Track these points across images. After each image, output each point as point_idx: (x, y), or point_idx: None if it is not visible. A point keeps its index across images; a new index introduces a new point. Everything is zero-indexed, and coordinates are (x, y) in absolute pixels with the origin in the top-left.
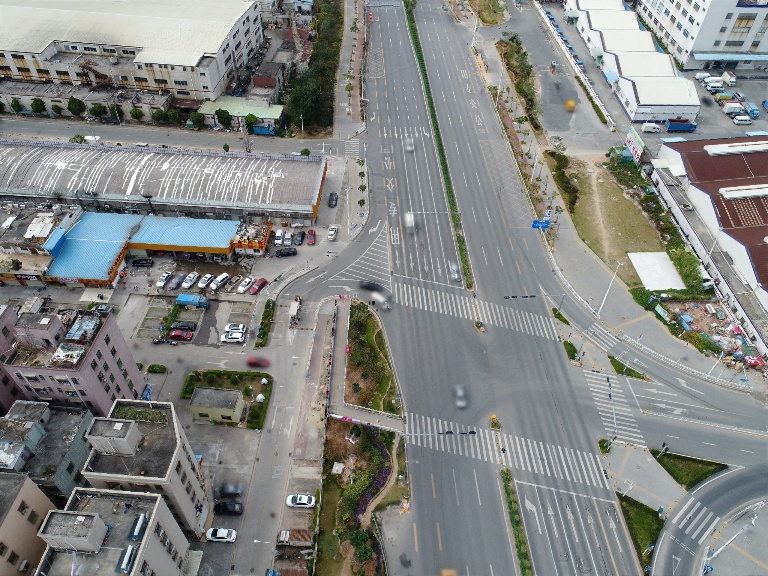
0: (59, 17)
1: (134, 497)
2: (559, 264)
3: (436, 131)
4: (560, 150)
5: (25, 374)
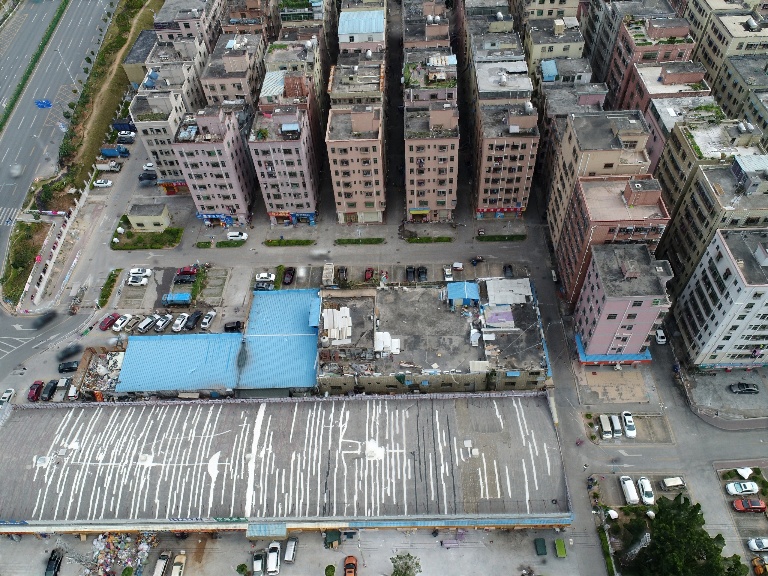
0: None
1: None
2: None
3: None
4: None
5: None
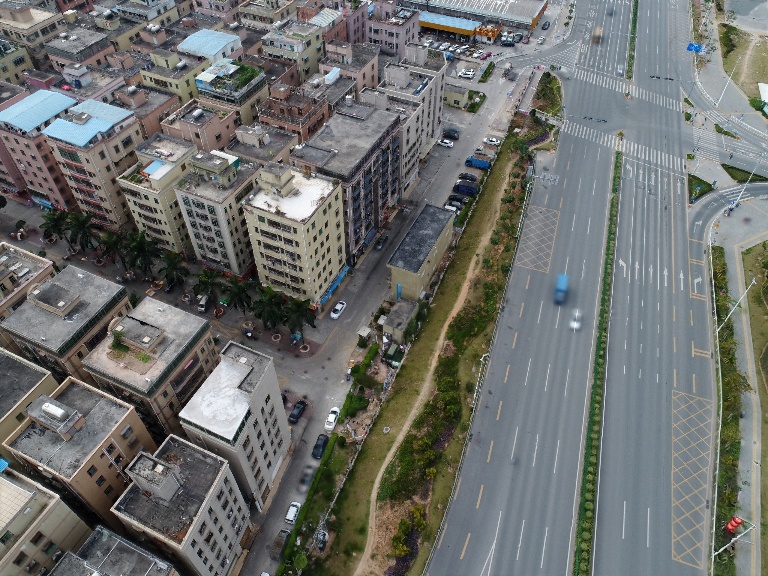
0: None
1: (422, 77)
2: (701, 80)
3: (636, 0)
4: (731, 19)
5: (374, 27)
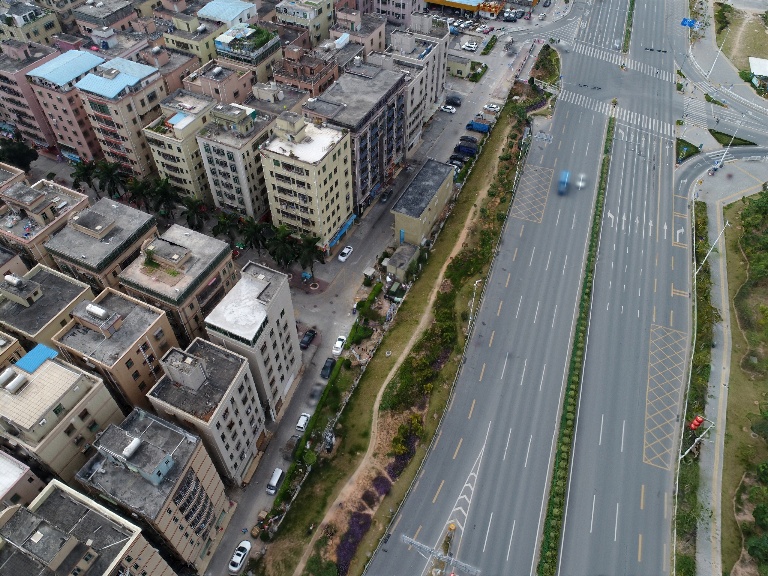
0: None
1: (427, 43)
2: (694, 54)
3: None
4: None
5: None
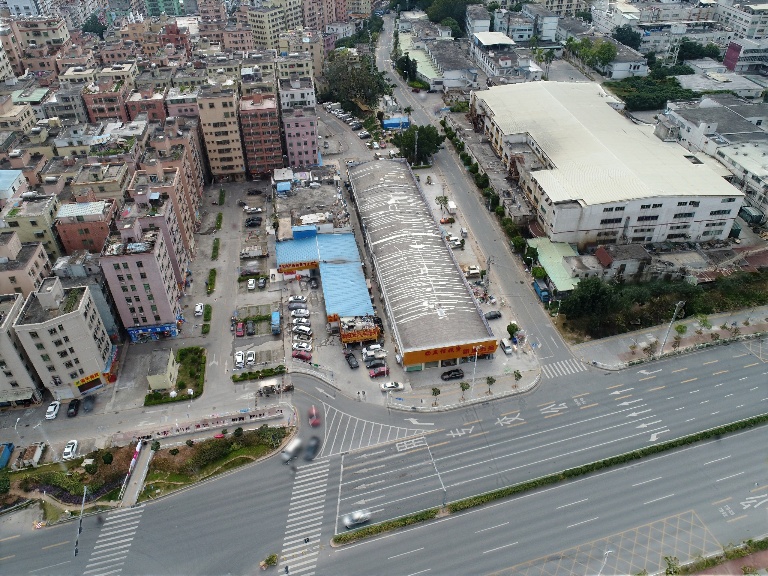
0: (563, 121)
1: None
2: None
3: None
4: None
5: None
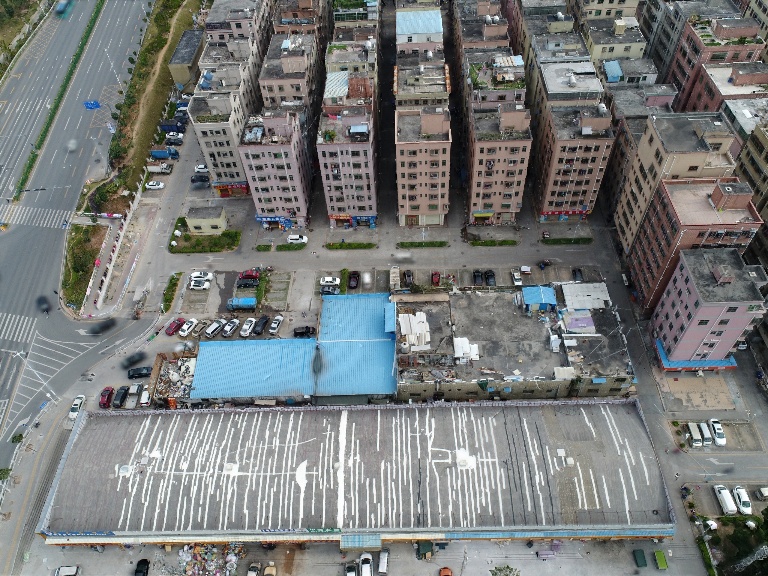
0: None
1: None
2: None
3: None
4: None
5: None
